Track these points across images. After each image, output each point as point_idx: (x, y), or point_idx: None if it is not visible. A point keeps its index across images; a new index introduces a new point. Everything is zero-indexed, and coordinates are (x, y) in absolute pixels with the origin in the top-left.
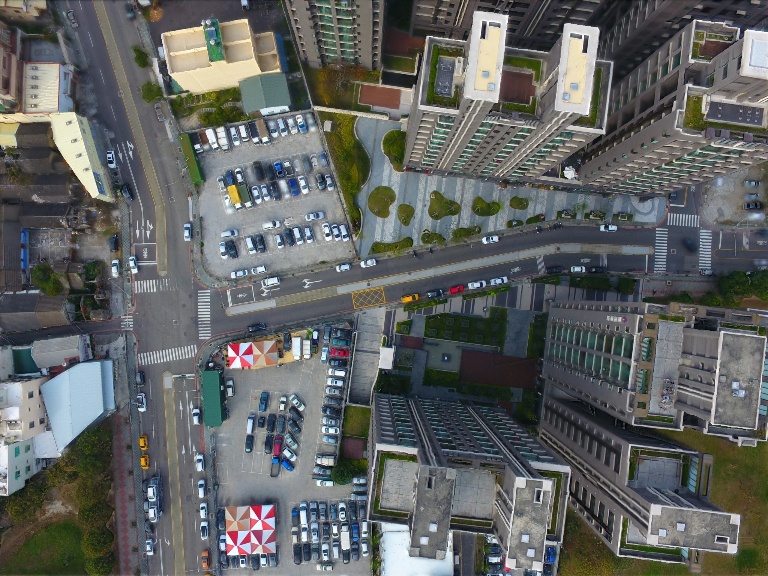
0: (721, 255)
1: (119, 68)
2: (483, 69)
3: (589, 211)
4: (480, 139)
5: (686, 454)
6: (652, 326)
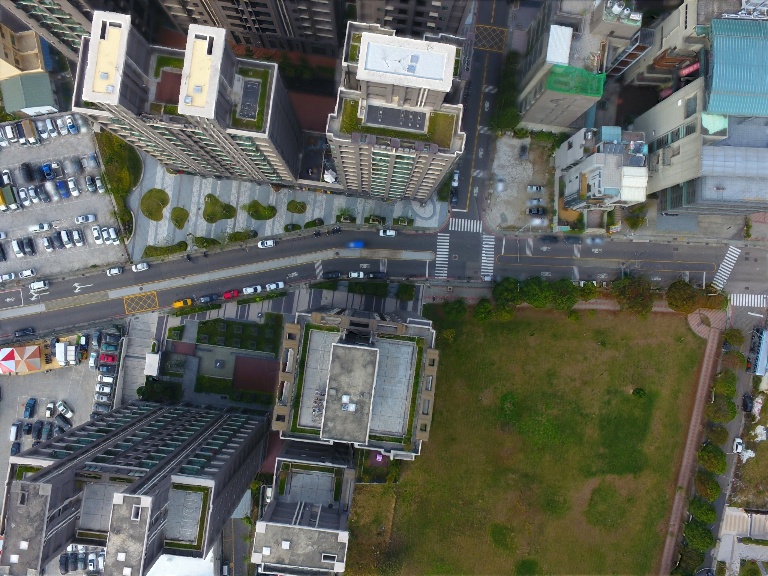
0: (504, 261)
1: None
2: (103, 70)
3: (369, 215)
4: (179, 142)
5: (338, 468)
6: (294, 336)
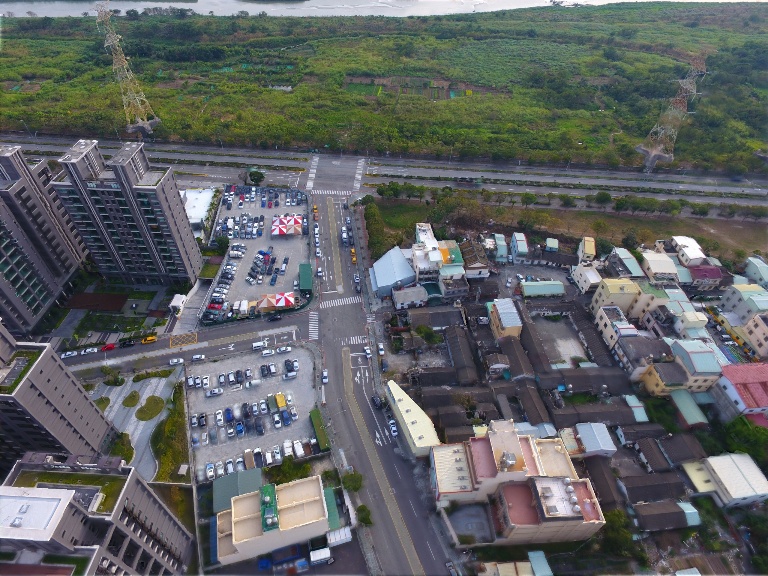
0: None
1: (397, 519)
2: None
3: None
4: None
5: None
6: None
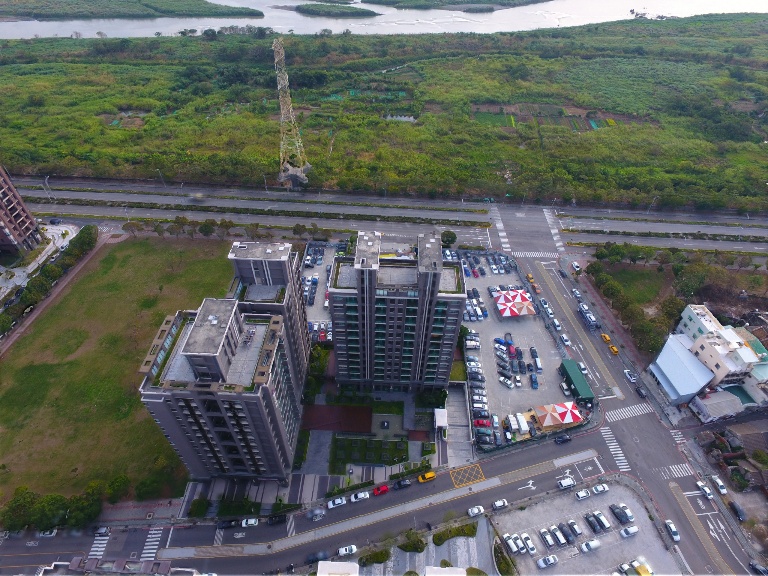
0: None
1: None
2: None
3: None
4: None
5: None
6: (260, 374)
